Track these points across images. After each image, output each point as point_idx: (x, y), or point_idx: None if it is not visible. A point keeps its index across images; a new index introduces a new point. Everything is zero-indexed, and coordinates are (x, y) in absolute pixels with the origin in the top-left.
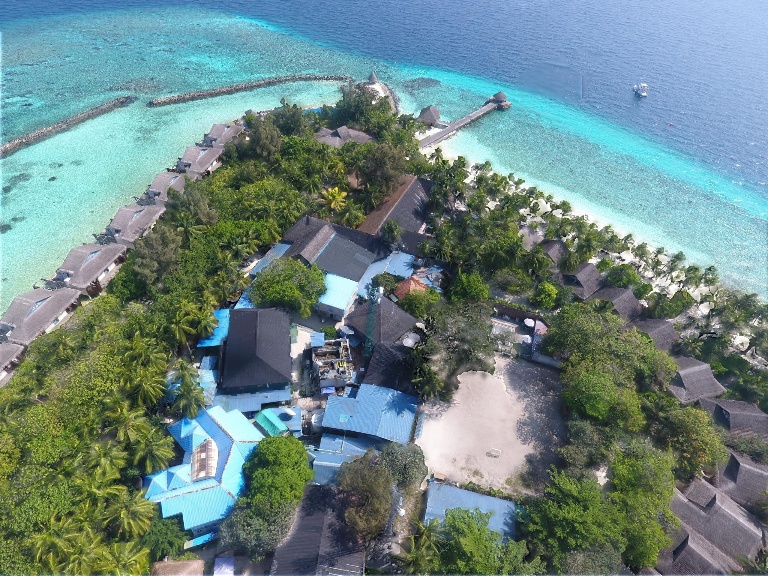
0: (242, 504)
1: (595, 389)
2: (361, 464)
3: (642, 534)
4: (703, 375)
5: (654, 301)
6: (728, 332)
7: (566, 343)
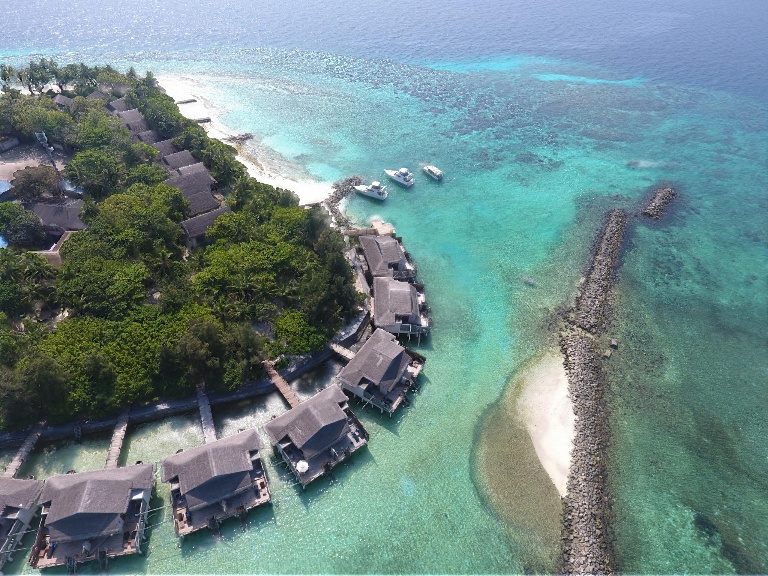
0: (5, 227)
1: (40, 112)
2: (17, 171)
3: (116, 129)
4: (63, 98)
5: (5, 98)
6: (46, 82)
7: (4, 116)
